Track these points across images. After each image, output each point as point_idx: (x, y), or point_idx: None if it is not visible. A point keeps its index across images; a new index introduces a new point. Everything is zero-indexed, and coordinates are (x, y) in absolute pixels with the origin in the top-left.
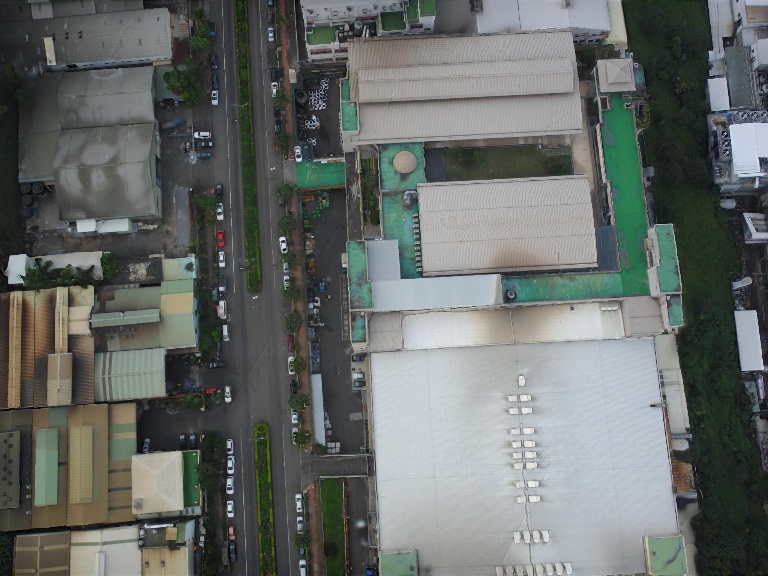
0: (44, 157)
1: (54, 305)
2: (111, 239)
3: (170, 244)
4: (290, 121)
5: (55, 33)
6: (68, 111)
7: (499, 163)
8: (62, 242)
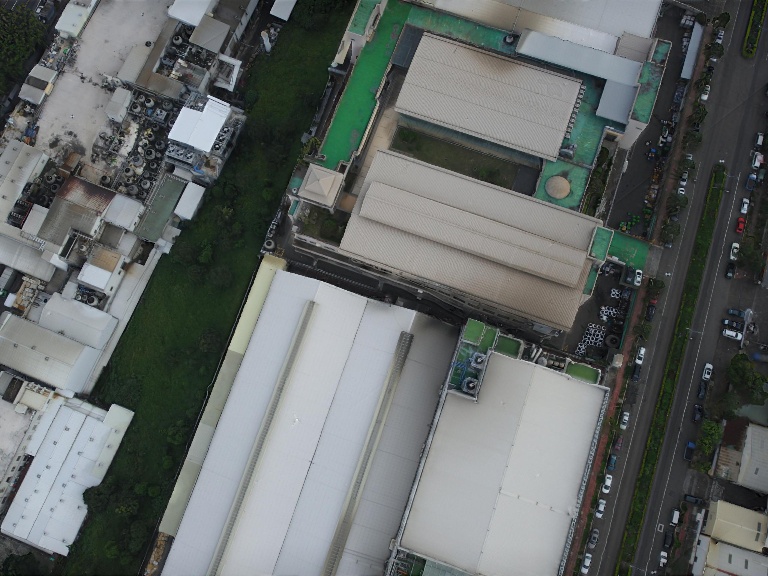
0: None
1: None
2: None
3: None
4: (635, 316)
5: None
6: None
7: (461, 165)
8: None
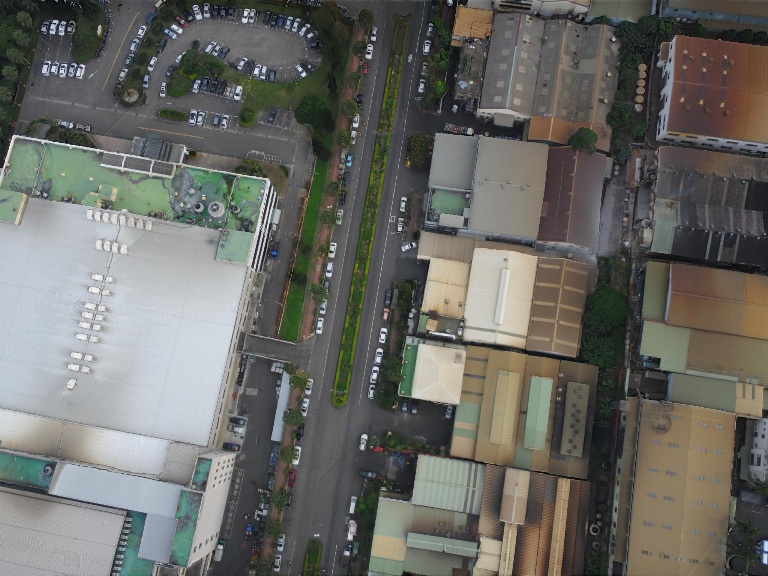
0: None
1: None
2: None
3: None
4: None
5: None
6: None
7: None
8: None
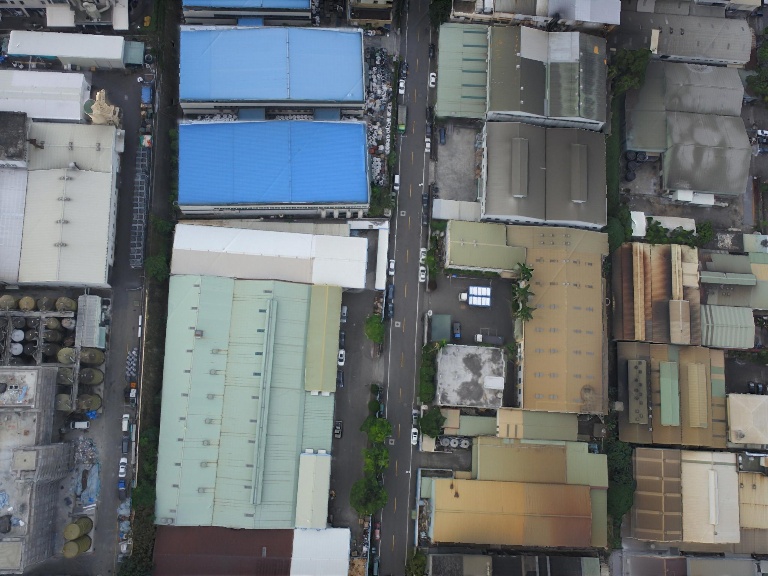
0: (650, 131)
1: (668, 259)
2: (690, 210)
3: (738, 221)
4: None
5: (661, 27)
6: (674, 96)
7: None
8: (650, 206)
